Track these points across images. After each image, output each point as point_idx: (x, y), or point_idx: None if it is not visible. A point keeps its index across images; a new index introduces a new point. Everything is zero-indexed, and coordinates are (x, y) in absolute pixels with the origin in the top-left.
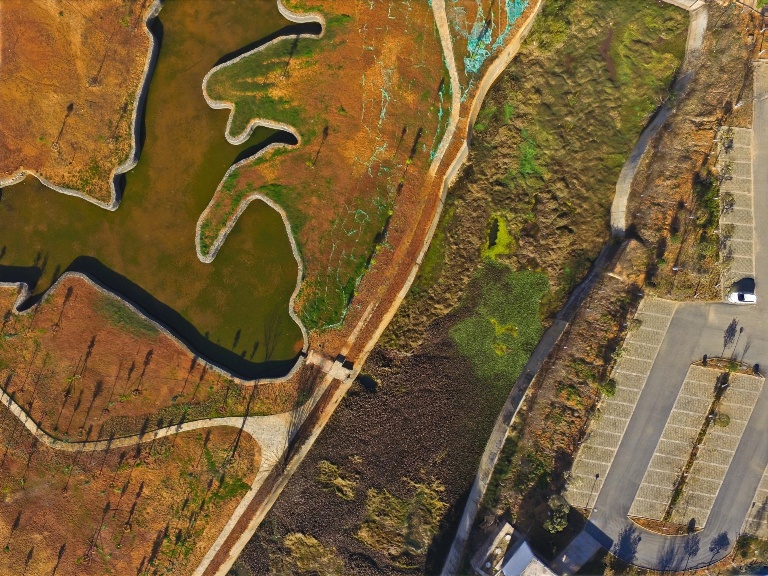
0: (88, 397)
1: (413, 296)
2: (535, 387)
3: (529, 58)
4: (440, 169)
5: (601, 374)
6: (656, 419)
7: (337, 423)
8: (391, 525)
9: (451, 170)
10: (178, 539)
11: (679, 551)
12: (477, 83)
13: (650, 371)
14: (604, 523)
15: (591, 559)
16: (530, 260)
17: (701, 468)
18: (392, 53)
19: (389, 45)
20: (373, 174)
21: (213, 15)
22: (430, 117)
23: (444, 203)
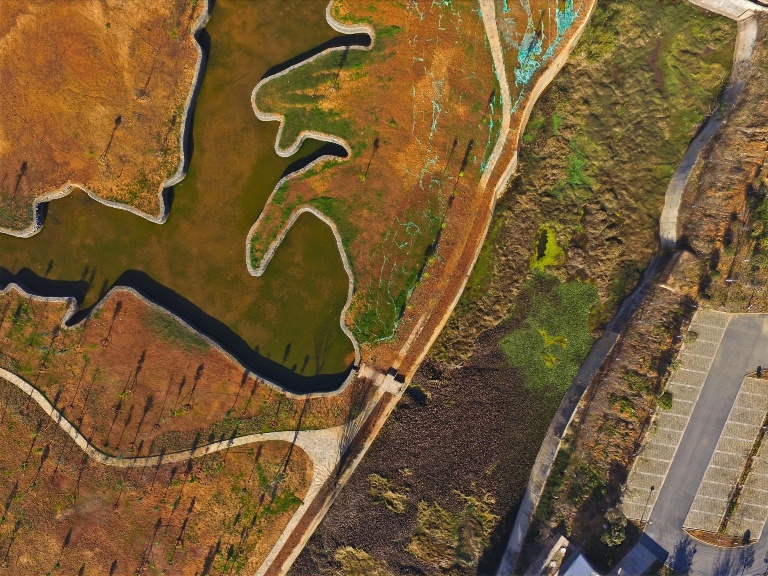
0: (139, 412)
1: (462, 308)
2: (587, 399)
3: (577, 68)
4: (491, 181)
5: (655, 386)
6: (710, 431)
7: (387, 436)
8: (441, 538)
9: (501, 182)
10: (230, 554)
11: (734, 563)
12: (527, 94)
13: (704, 383)
14: (659, 535)
15: (646, 571)
16: (579, 271)
17: (756, 480)
18: (443, 64)
19: (440, 56)
20: (424, 186)
21: (261, 26)
22: (481, 129)
23: (493, 214)
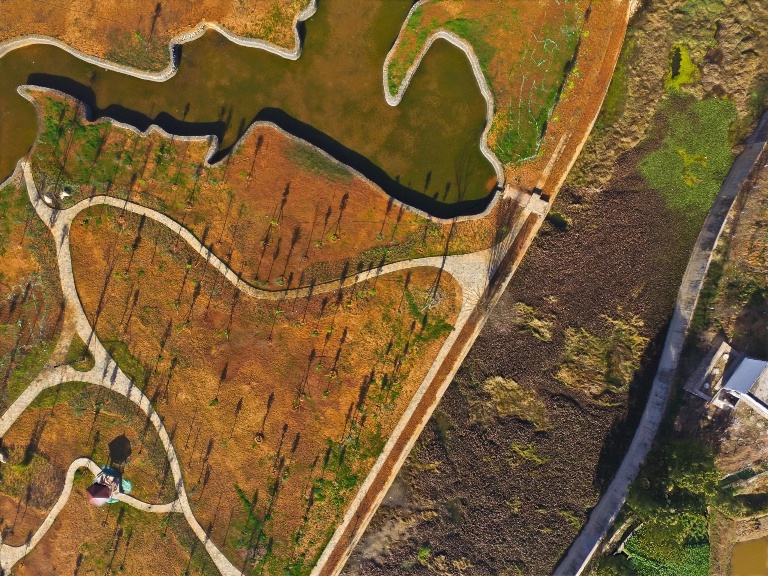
0: (286, 245)
1: (598, 131)
2: (737, 209)
3: None
4: None
5: None
6: None
7: (530, 264)
8: (590, 364)
9: None
10: (384, 383)
11: None
12: None
13: None
14: None
15: None
16: (715, 88)
17: None
18: None
19: None
20: (560, 1)
21: None
22: None
23: None
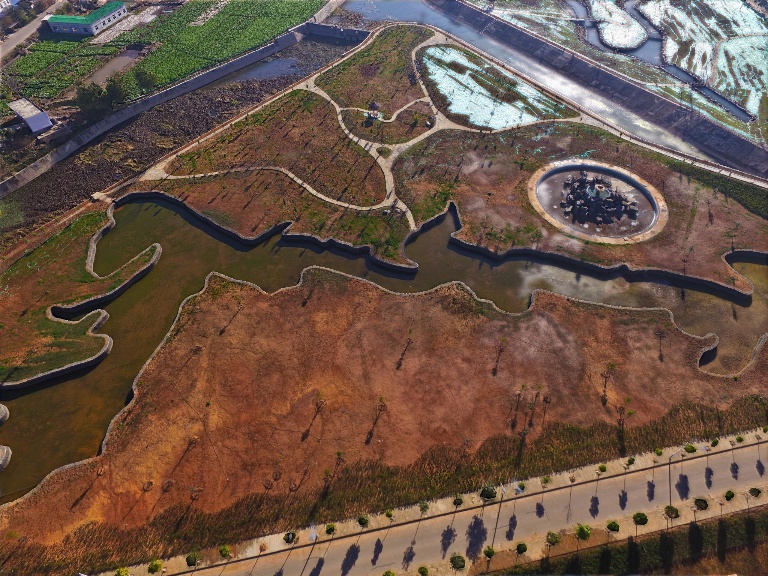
0: None
1: None
2: None
3: None
4: None
5: None
6: None
7: None
8: None
9: None
10: None
11: None
12: None
13: None
14: None
15: None
16: None
17: None
18: None
19: None
20: (5, 287)
21: (74, 412)
22: None
23: None
